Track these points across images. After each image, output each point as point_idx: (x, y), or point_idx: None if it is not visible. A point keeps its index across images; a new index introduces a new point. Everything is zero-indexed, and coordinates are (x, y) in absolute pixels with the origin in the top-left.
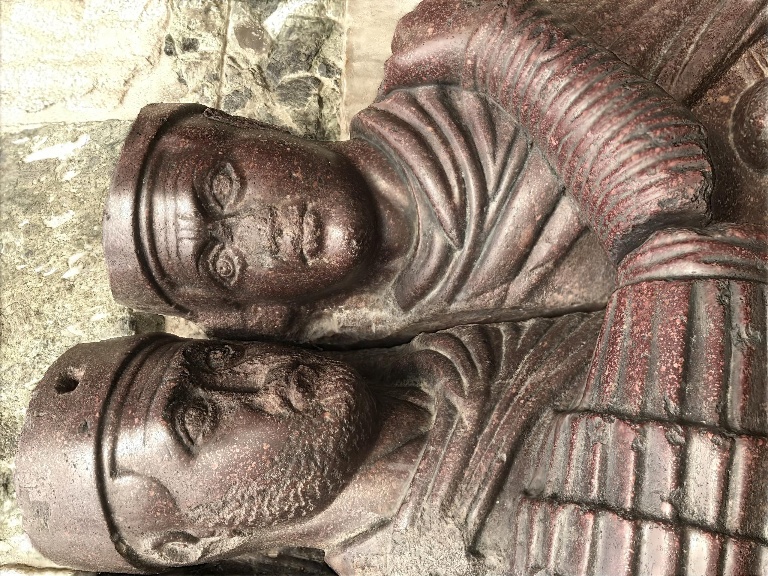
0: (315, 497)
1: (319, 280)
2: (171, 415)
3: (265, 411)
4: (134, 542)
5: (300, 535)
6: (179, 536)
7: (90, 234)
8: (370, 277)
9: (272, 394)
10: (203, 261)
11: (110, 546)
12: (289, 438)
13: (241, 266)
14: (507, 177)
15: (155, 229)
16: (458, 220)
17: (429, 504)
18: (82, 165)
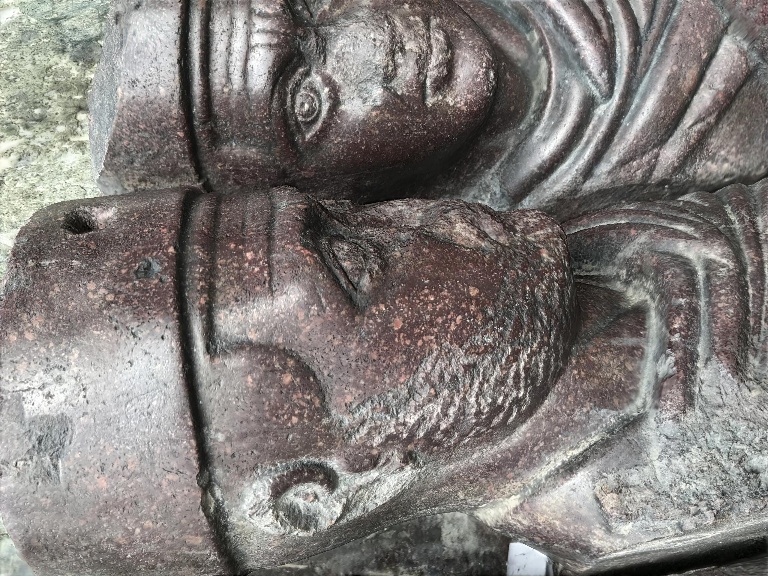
0: (535, 383)
1: (433, 135)
2: (313, 244)
3: (458, 244)
4: (232, 491)
5: (487, 468)
6: (317, 470)
7: (29, 117)
8: (465, 162)
9: (460, 222)
10: (281, 87)
11: (192, 498)
12: (503, 280)
13: (332, 104)
14: (661, 12)
15: (212, 31)
16: (609, 59)
17: (714, 368)
18: (9, 38)
